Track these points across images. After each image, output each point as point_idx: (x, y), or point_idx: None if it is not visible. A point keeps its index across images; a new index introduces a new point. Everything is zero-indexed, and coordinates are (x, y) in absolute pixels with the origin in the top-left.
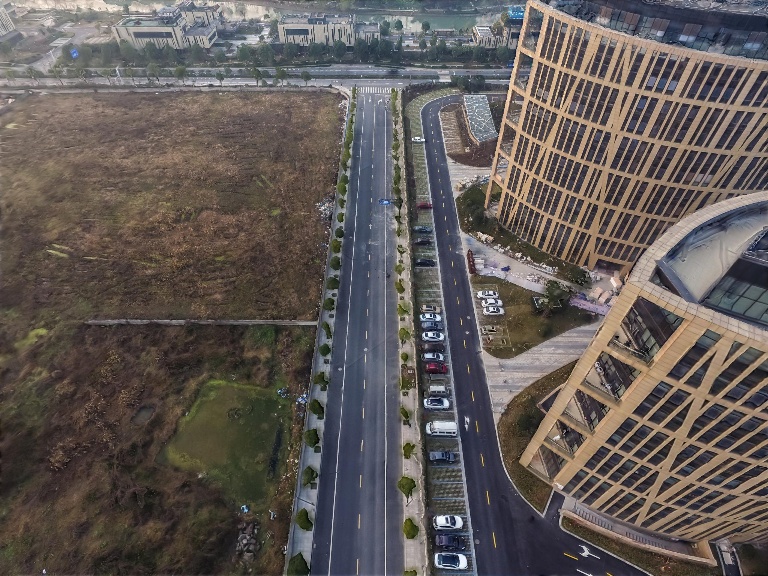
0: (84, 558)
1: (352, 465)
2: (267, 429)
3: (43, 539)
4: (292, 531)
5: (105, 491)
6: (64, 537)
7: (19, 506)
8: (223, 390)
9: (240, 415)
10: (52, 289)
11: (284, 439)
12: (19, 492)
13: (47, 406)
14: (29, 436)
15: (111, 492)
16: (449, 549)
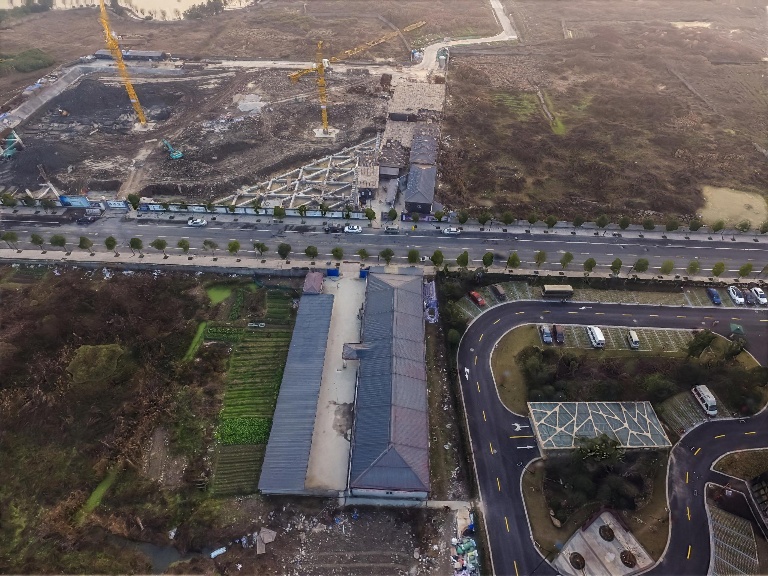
0: (648, 170)
1: (759, 256)
2: (750, 220)
3: (646, 159)
4: (704, 231)
5: (676, 170)
6: (651, 164)
7: (653, 150)
8: (759, 201)
9: (749, 209)
10: (761, 127)
11: (750, 228)
12: (658, 148)
13: (698, 144)
14: (682, 142)
15: (677, 171)
16: (743, 294)
